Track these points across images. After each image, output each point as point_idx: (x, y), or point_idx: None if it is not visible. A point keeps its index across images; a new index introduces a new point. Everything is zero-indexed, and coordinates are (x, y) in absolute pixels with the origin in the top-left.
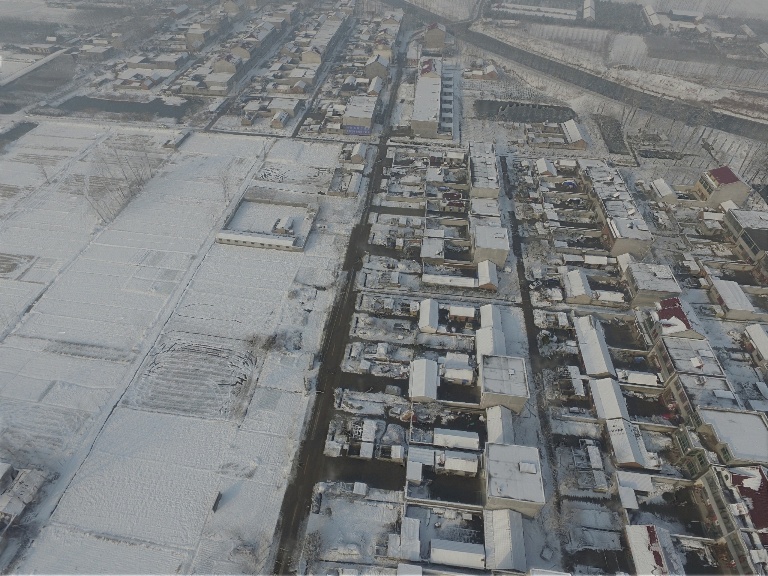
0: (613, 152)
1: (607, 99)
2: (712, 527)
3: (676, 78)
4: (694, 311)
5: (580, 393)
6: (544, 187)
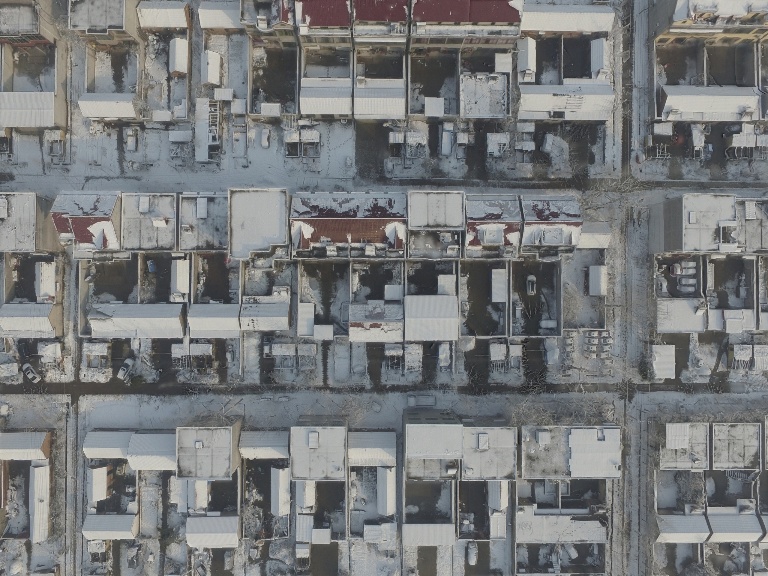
0: None
1: None
2: None
3: None
4: (58, 166)
5: (209, 350)
6: None
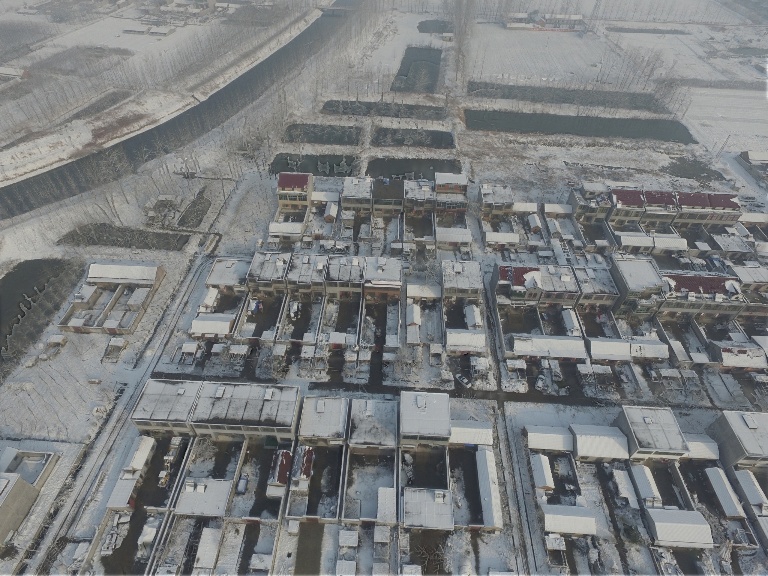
0: (179, 248)
1: (27, 217)
2: (680, 318)
3: (20, 145)
4: None
5: (609, 369)
6: (263, 335)
